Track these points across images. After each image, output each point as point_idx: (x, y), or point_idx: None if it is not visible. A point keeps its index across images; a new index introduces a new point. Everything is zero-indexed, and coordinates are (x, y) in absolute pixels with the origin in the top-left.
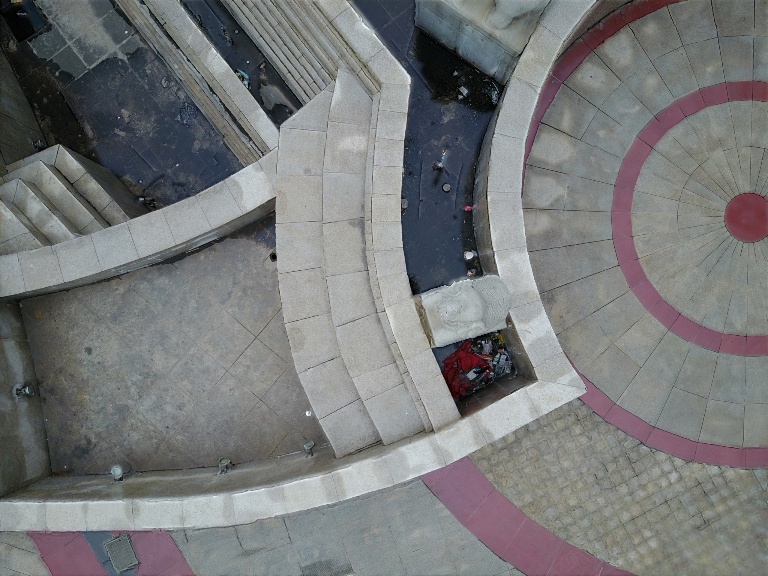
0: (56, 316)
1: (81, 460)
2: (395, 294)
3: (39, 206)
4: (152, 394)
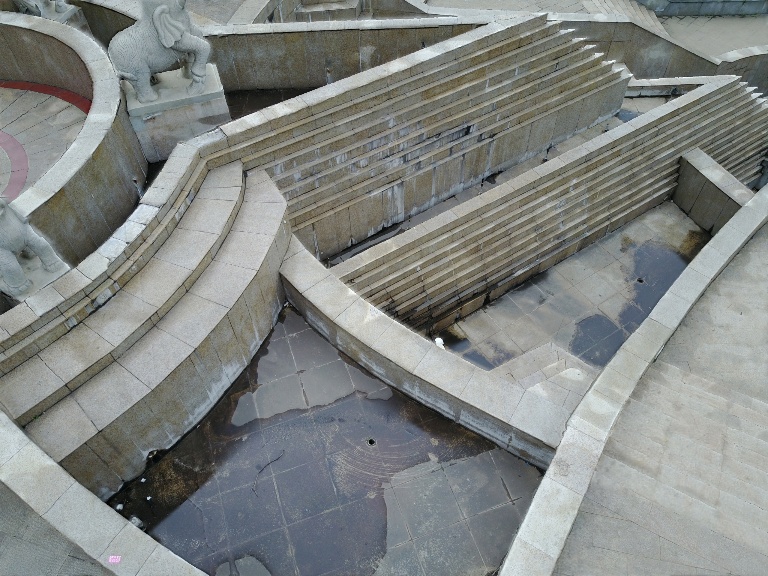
0: None
1: None
2: None
3: (335, 8)
4: (203, 2)
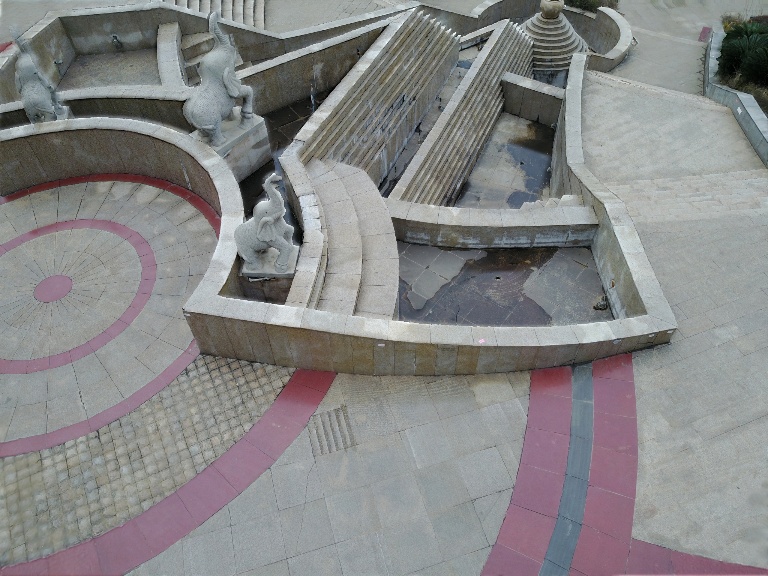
0: (154, 57)
1: (79, 64)
2: (70, 95)
3: None
4: (99, 83)
